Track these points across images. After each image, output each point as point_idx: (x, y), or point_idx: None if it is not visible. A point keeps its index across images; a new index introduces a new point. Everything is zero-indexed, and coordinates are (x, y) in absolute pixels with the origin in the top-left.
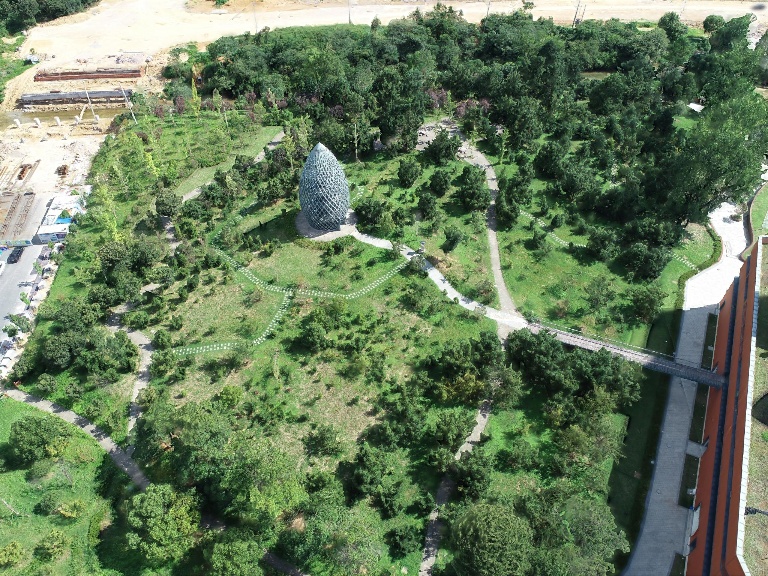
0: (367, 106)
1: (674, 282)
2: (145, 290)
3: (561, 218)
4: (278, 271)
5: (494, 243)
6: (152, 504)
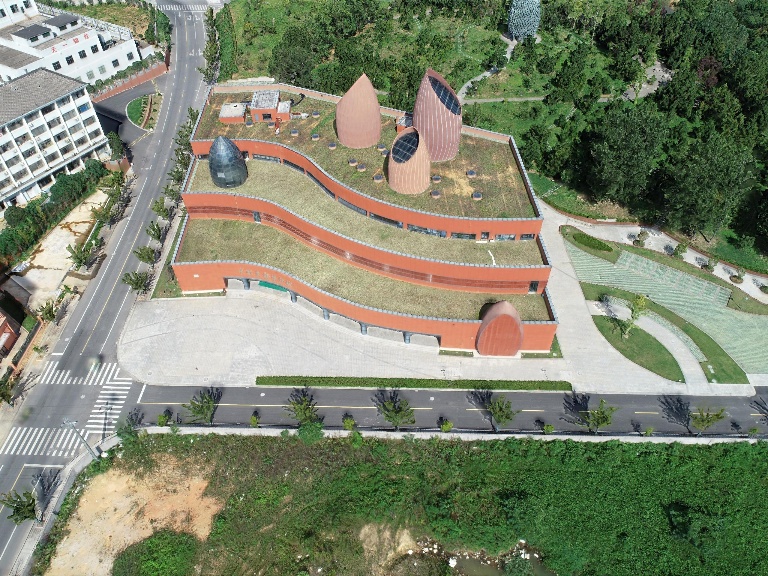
0: None
1: None
2: None
3: None
4: None
5: (529, 99)
6: (330, 5)
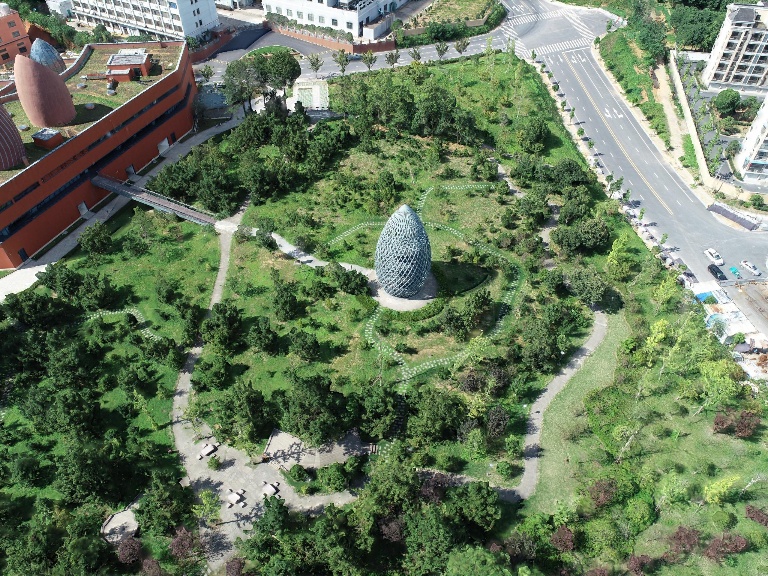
0: (378, 516)
1: (42, 287)
2: (550, 230)
3: (122, 325)
4: (436, 238)
5: (216, 295)
6: None
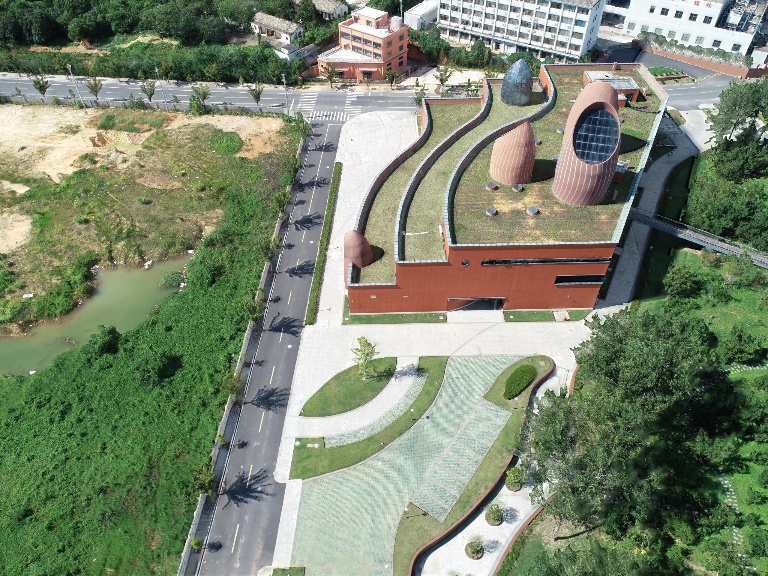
0: None
1: None
2: None
3: None
4: None
5: None
6: None
